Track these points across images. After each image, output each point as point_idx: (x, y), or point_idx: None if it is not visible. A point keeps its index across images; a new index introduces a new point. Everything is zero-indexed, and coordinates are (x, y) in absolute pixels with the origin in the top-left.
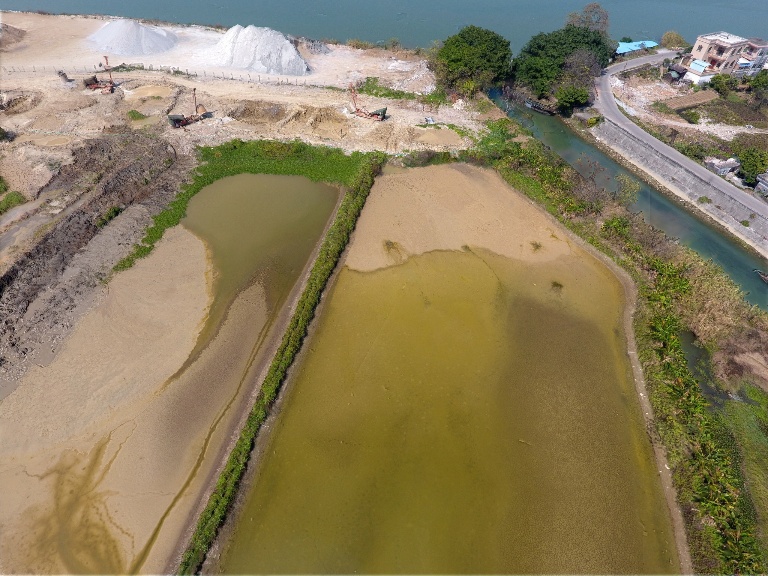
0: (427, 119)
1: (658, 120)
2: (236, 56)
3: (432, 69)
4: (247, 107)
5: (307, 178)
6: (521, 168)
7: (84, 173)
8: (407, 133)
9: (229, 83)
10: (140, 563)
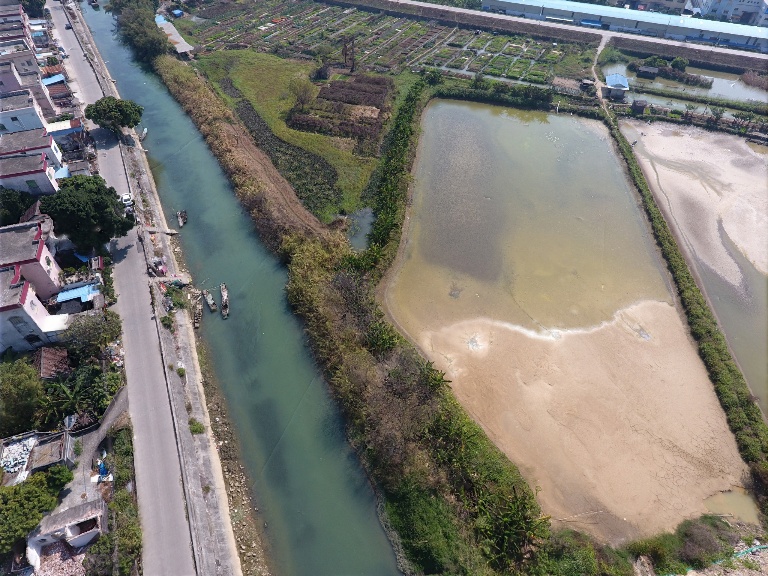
0: None
1: None
2: None
3: None
4: None
5: None
6: None
7: None
8: None
9: None
10: (652, 164)
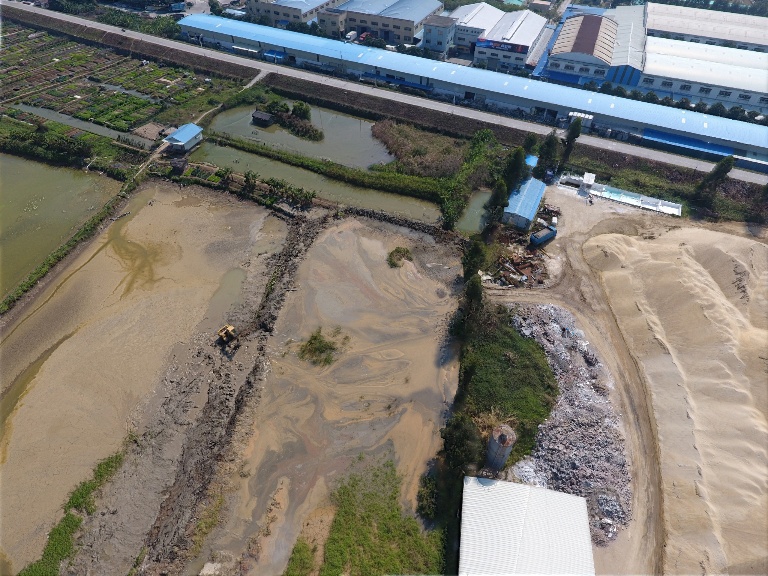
0: None
1: None
2: None
3: None
4: None
5: None
6: None
7: None
8: None
9: None
10: (102, 247)
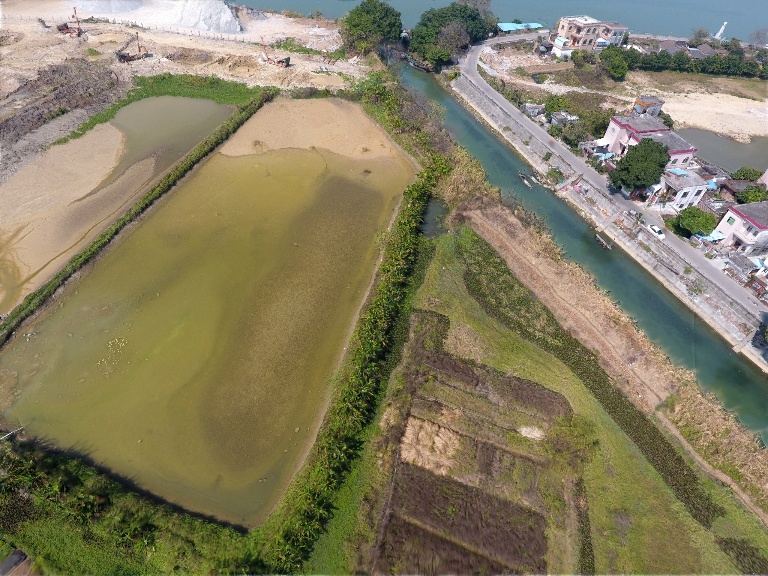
0: (321, 67)
1: (511, 79)
2: (185, 16)
3: None
4: (183, 53)
5: (213, 101)
6: (379, 103)
7: (44, 86)
8: (301, 76)
9: (174, 36)
10: (32, 277)
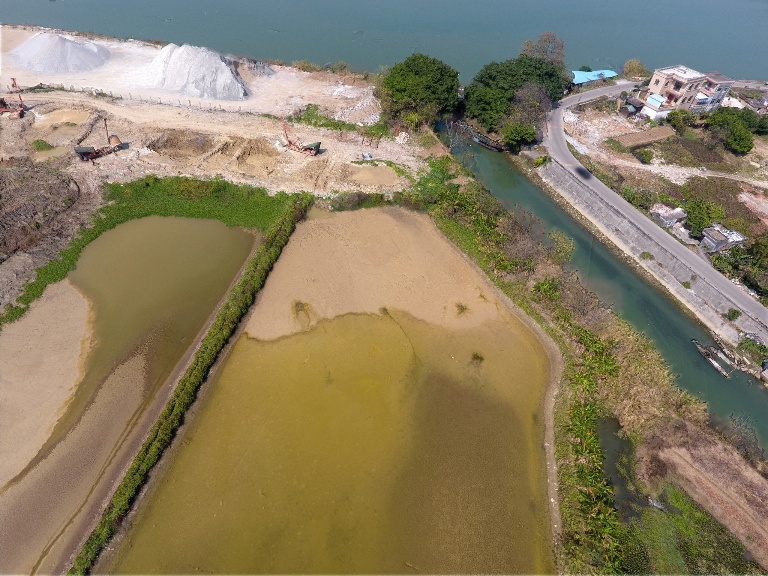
0: (363, 155)
1: (609, 159)
2: (168, 77)
3: (379, 96)
4: (170, 137)
5: (222, 222)
6: (457, 214)
7: None
8: (340, 171)
9: (156, 108)
10: None
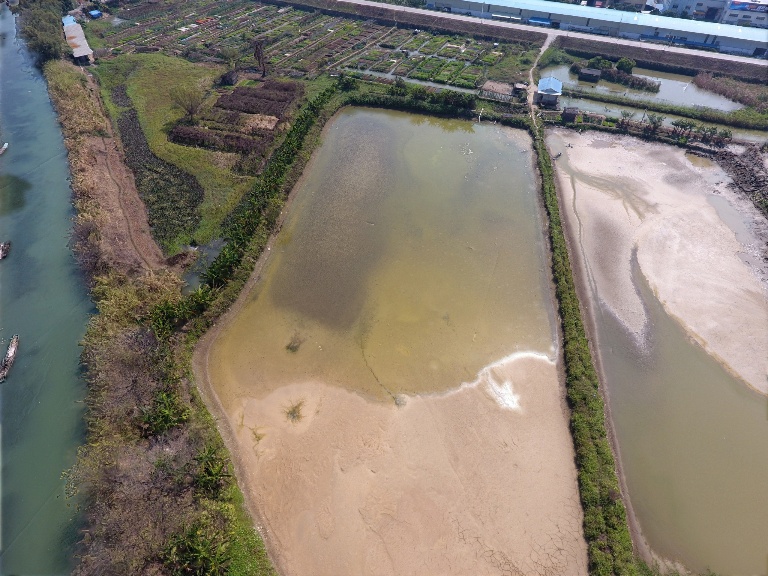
0: None
1: None
2: None
3: None
4: None
5: None
6: None
7: None
8: None
9: None
10: (572, 181)
